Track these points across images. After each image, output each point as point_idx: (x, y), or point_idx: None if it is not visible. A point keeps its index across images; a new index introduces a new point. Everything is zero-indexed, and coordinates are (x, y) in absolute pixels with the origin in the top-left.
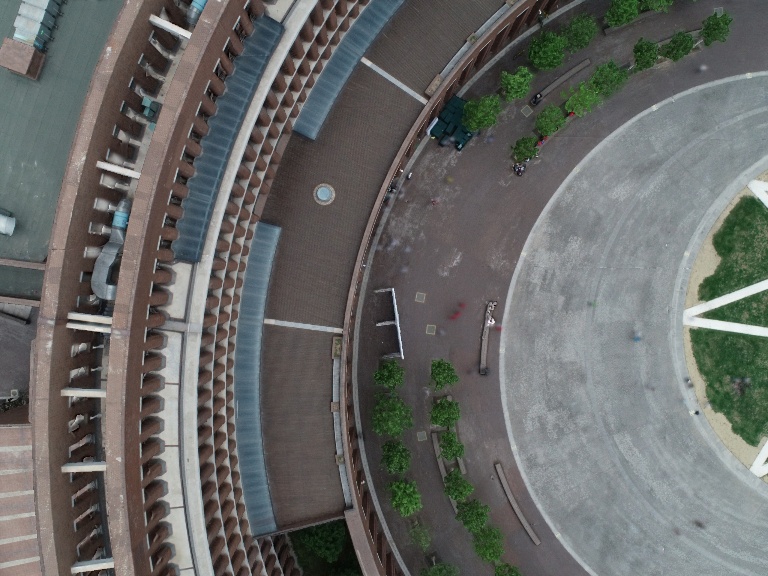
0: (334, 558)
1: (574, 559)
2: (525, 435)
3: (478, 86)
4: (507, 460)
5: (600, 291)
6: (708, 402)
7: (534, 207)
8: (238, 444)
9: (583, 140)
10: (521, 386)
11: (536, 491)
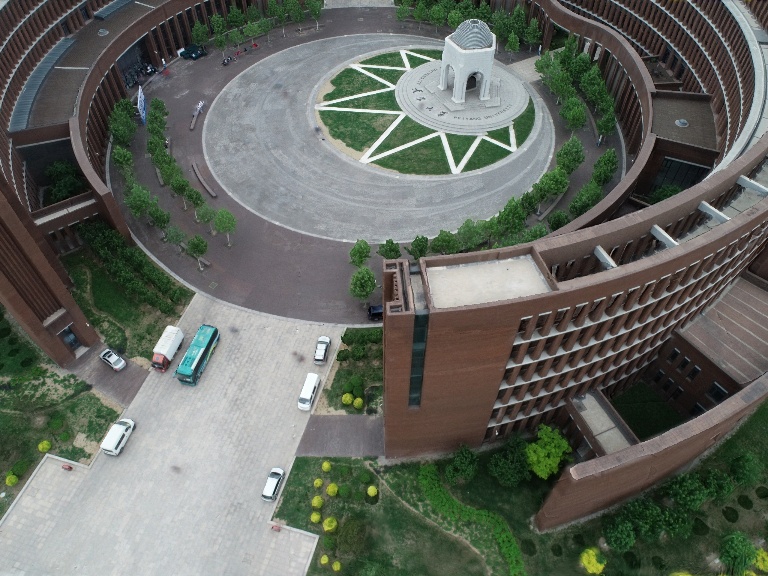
0: (62, 171)
1: (240, 204)
2: (214, 153)
3: None
4: (201, 163)
5: (266, 100)
6: (330, 136)
7: (232, 75)
8: (18, 102)
9: (261, 55)
10: (215, 134)
11: (218, 175)
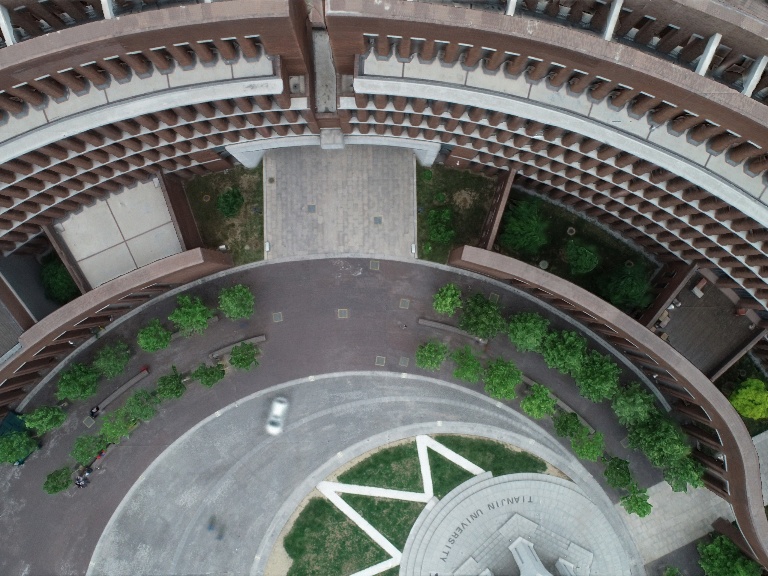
0: None
1: None
2: None
3: (38, 399)
4: None
5: None
6: None
7: (101, 517)
8: None
9: (147, 449)
10: None
11: None
